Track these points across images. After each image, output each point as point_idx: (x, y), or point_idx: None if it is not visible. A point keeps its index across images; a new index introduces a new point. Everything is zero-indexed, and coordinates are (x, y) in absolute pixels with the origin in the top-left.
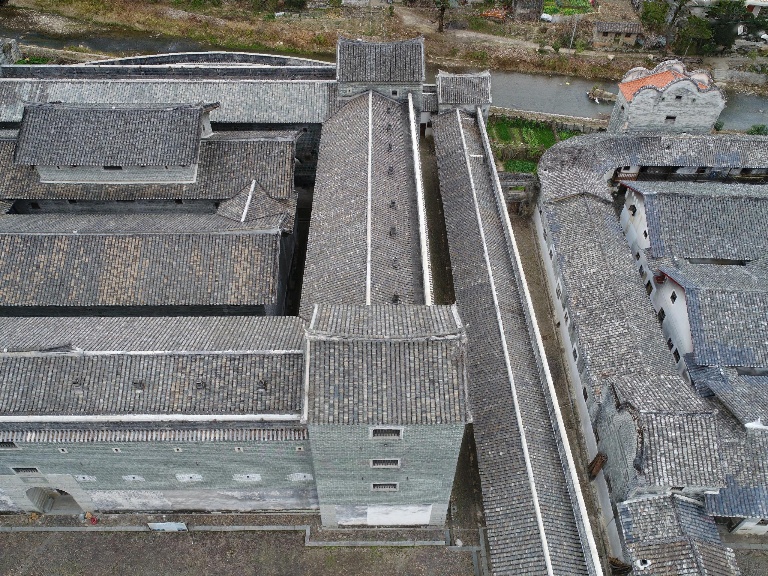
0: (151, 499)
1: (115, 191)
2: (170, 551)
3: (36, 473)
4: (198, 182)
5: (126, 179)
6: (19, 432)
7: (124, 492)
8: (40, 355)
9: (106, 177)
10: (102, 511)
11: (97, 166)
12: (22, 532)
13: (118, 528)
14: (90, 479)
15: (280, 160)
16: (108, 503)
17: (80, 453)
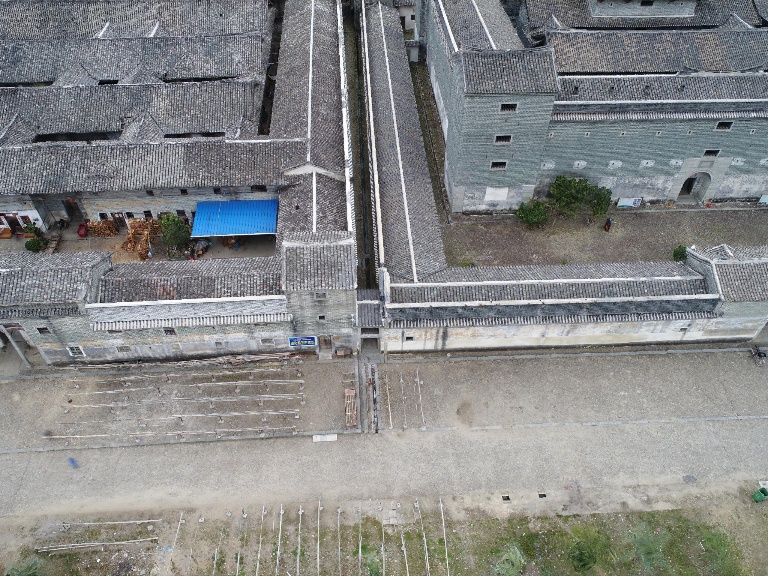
0: (756, 185)
1: (644, 22)
2: (767, 217)
3: (713, 157)
4: (696, 16)
5: (649, 14)
6: (746, 112)
7: (747, 177)
8: (739, 75)
9: (637, 12)
10: (713, 200)
11: (637, 3)
12: (669, 212)
13: (726, 209)
14: (740, 162)
15: (745, 2)
16: (726, 190)
17: (759, 134)
